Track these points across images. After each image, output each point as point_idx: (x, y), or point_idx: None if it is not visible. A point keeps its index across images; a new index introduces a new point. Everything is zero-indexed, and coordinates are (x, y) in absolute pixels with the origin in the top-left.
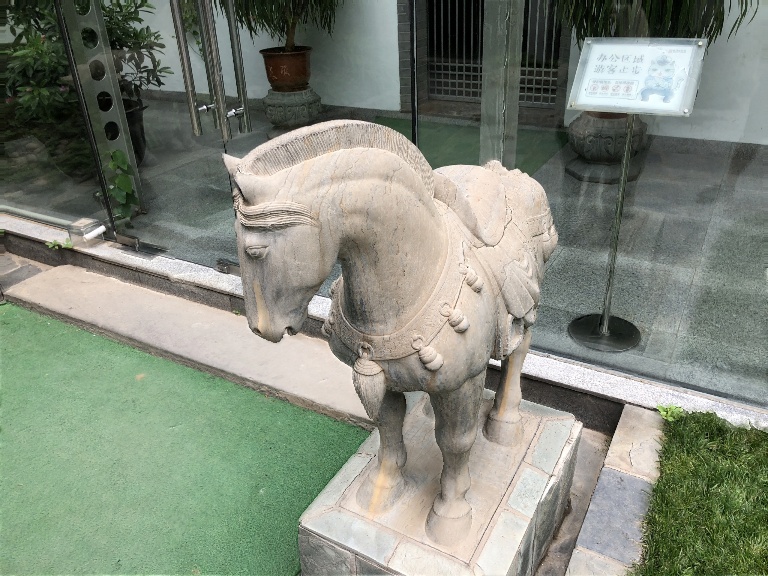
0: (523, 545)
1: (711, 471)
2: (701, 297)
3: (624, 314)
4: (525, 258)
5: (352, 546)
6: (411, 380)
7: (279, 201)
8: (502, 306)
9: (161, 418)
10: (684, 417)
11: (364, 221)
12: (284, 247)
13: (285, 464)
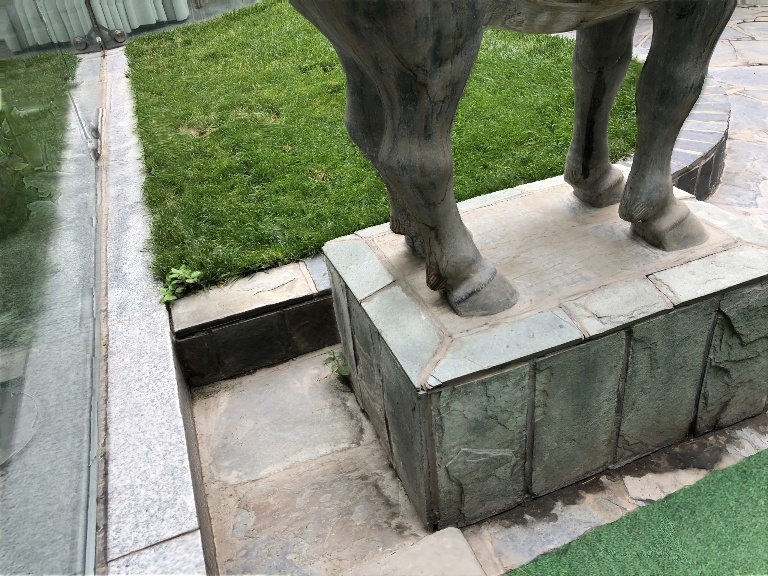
0: None
1: None
2: None
3: None
4: None
5: None
6: None
7: None
8: None
9: None
10: None
11: None
12: None
13: None
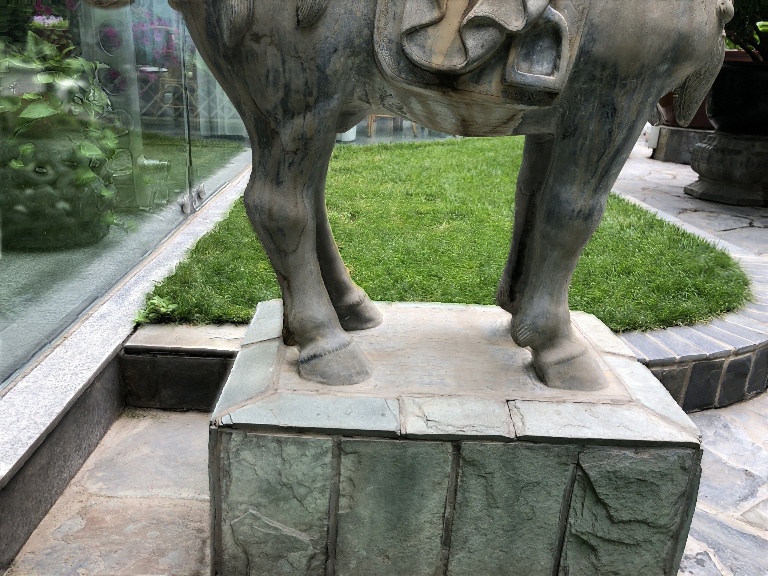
0: None
1: None
2: None
3: None
4: None
5: None
6: None
7: None
8: None
9: None
10: None
11: None
12: None
13: None
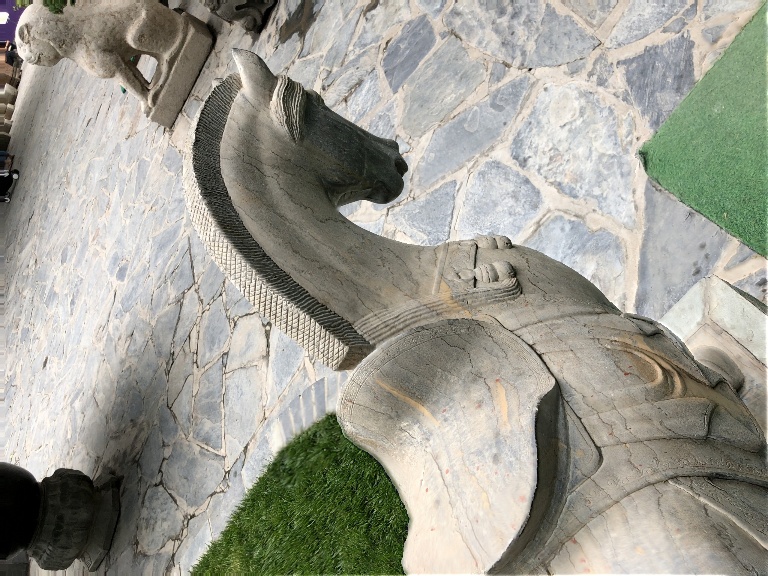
0: None
1: None
2: None
3: None
4: None
5: None
6: None
7: None
8: None
9: None
10: None
11: None
12: None
13: None
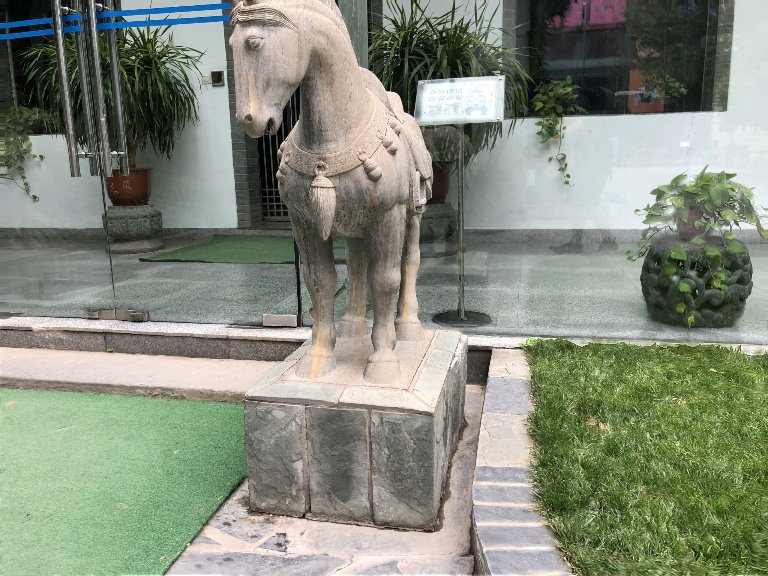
0: (445, 390)
1: None
2: (528, 300)
3: None
4: (420, 142)
5: (302, 397)
6: (357, 195)
7: (273, 5)
8: (412, 161)
9: (46, 424)
10: (540, 342)
11: (326, 43)
12: (275, 41)
13: (195, 434)
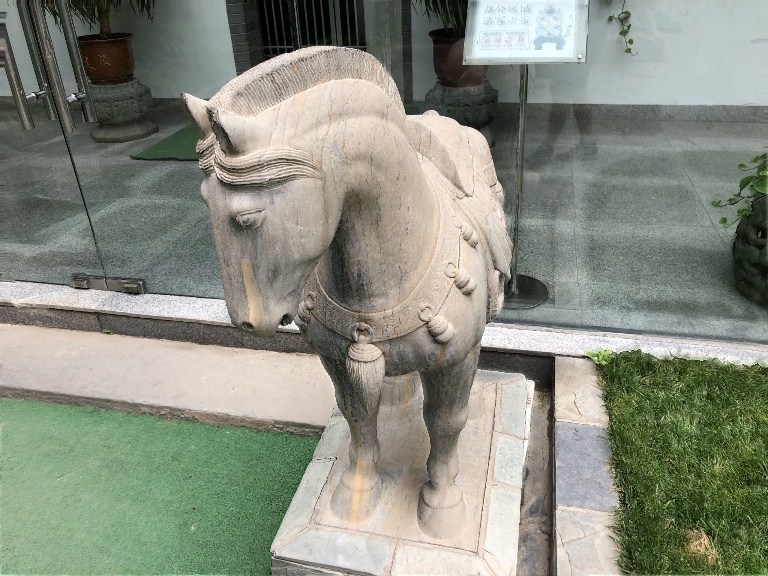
0: None
1: (653, 405)
2: (587, 245)
3: (525, 271)
4: (497, 208)
5: (344, 565)
6: (416, 359)
7: (275, 147)
8: (490, 262)
9: (42, 470)
10: (615, 358)
11: (368, 169)
12: (284, 209)
13: (213, 491)
